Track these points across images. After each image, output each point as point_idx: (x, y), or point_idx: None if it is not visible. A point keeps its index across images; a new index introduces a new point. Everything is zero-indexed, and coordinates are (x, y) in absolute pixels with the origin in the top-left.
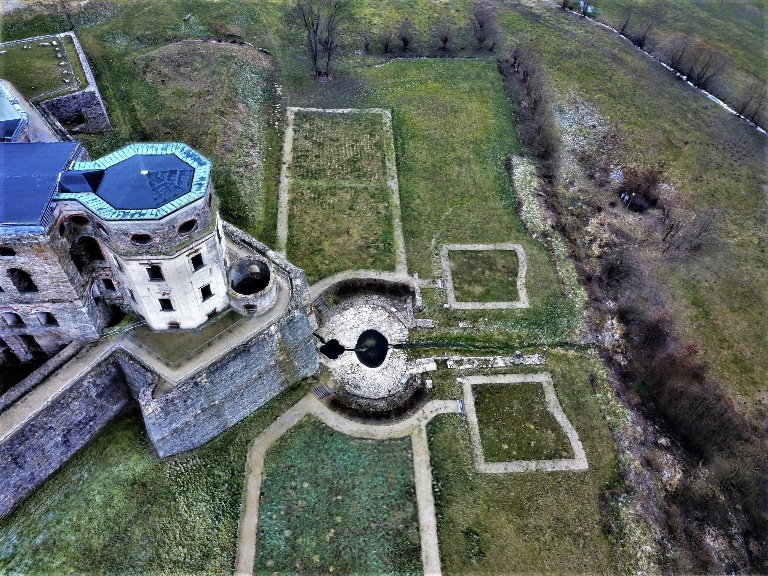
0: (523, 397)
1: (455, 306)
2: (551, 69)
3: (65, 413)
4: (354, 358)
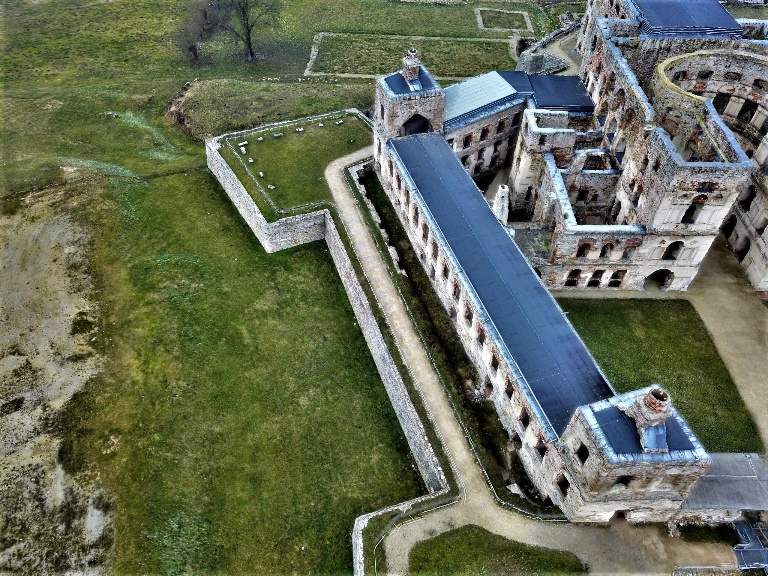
0: None
1: None
2: None
3: None
4: None
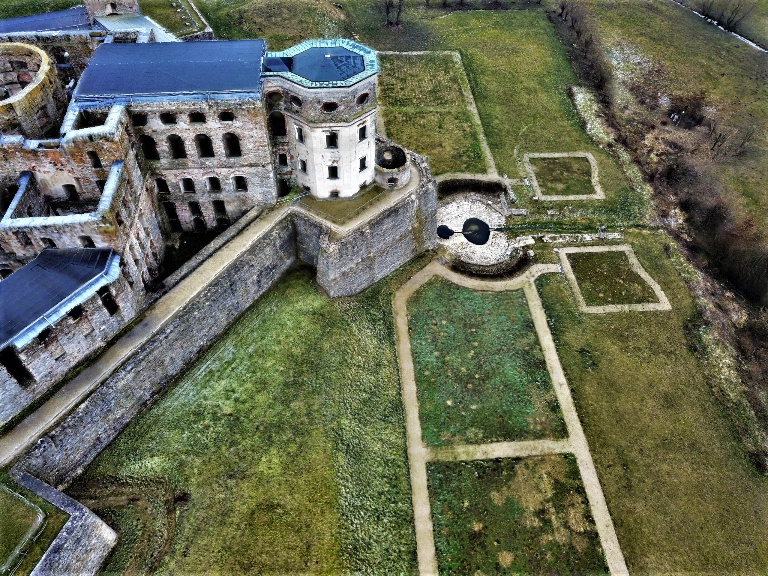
0: (610, 261)
1: (542, 198)
2: (595, 18)
3: (261, 255)
4: (463, 238)
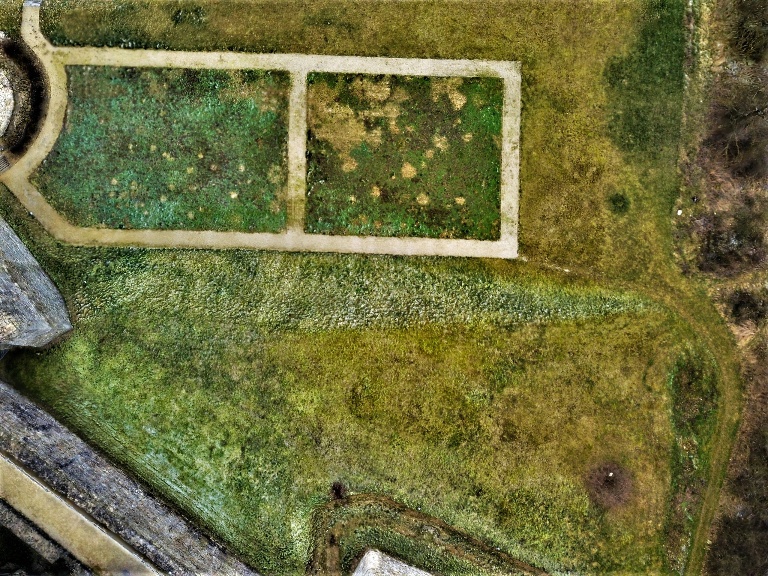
0: None
1: None
2: None
3: (6, 428)
4: None
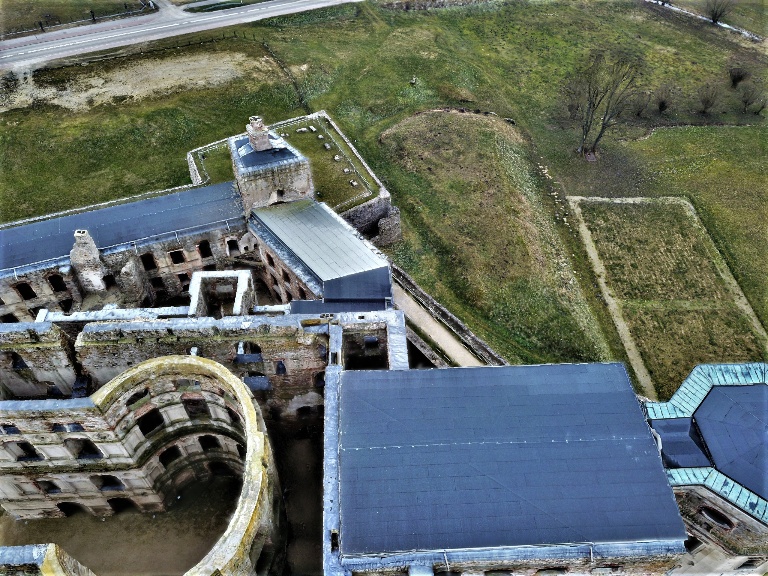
0: None
1: None
2: None
3: None
4: None
